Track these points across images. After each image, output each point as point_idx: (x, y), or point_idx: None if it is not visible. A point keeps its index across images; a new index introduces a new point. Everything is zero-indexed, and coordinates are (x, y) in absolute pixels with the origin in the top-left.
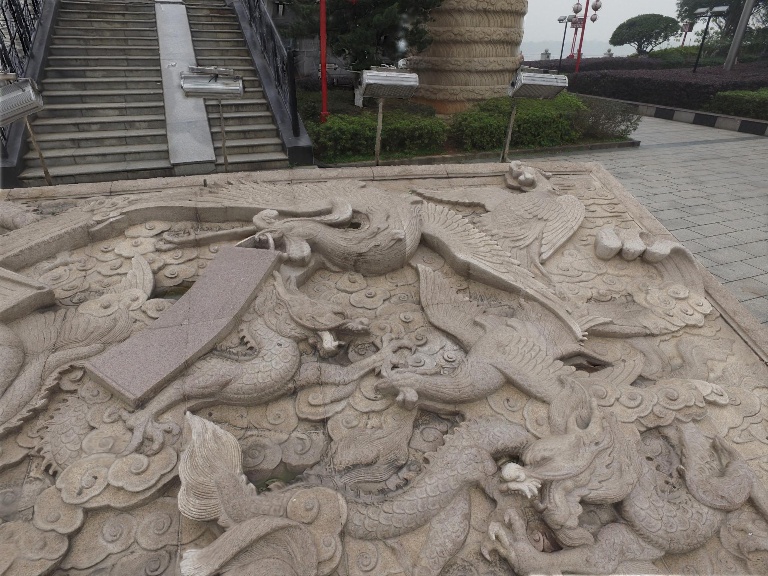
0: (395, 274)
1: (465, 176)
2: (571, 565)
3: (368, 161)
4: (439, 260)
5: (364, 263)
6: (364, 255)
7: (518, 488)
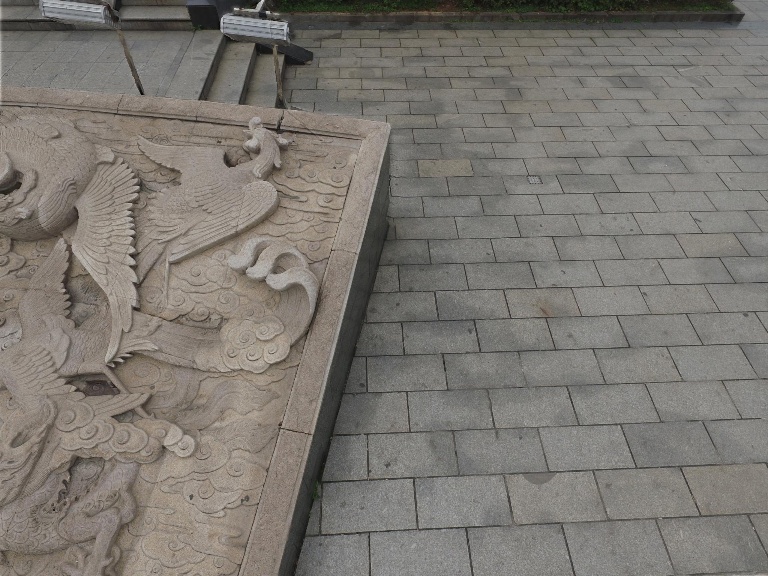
0: (46, 242)
1: (215, 122)
2: None
3: (333, 12)
4: None
5: (0, 232)
6: None
7: None
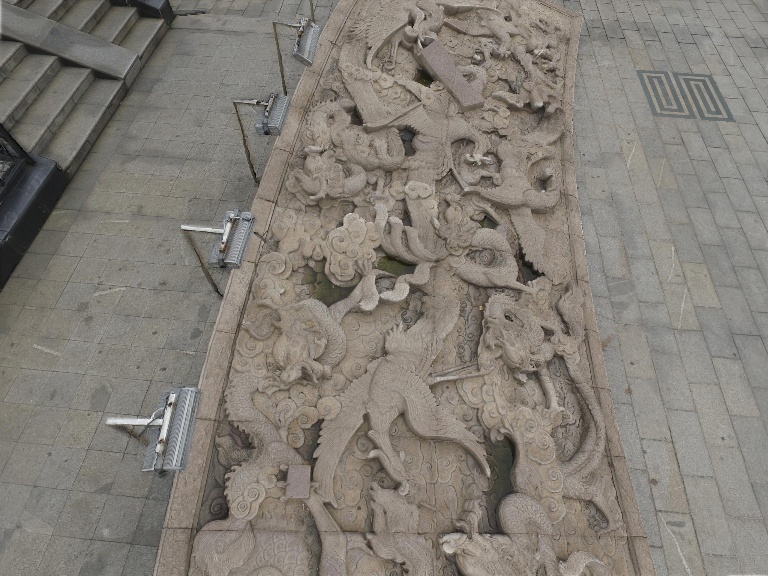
0: None
1: None
2: (555, 61)
3: None
4: None
5: None
6: (442, 25)
7: (541, 53)
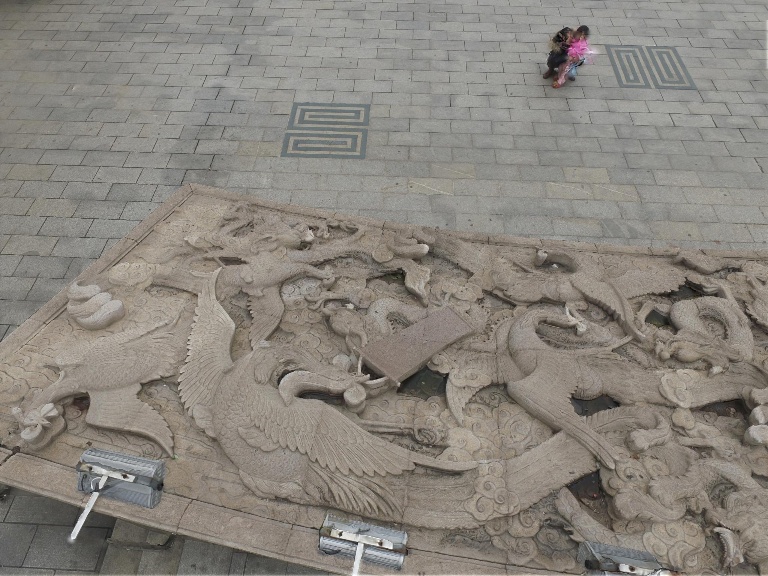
0: None
1: None
2: None
3: None
4: (234, 356)
5: None
6: None
7: None
